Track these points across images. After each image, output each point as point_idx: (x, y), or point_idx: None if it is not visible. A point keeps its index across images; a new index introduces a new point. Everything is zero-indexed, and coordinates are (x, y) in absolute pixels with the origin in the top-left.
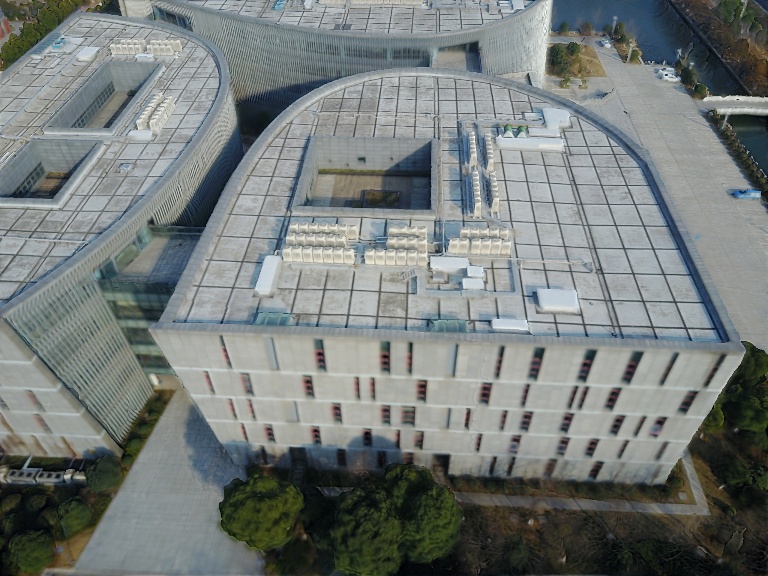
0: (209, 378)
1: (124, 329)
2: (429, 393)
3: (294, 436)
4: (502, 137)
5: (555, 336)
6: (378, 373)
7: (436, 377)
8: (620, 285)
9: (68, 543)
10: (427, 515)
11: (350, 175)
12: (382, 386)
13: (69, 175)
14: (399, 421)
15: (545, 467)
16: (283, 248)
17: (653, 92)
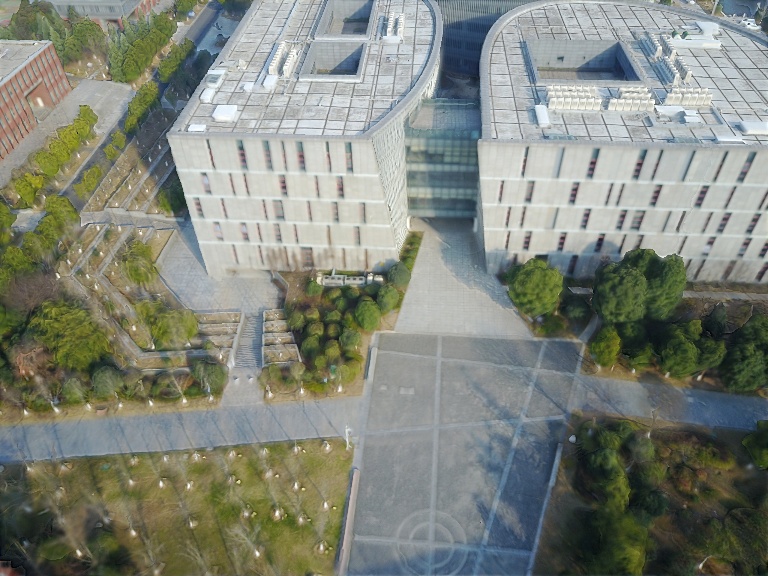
0: (502, 188)
1: (407, 172)
2: (660, 197)
3: (544, 243)
4: (673, 39)
5: None
6: (629, 179)
7: (671, 181)
8: None
9: (383, 318)
10: (671, 271)
11: (550, 71)
12: (628, 191)
13: (335, 71)
14: (628, 226)
15: (724, 270)
16: (551, 98)
17: None
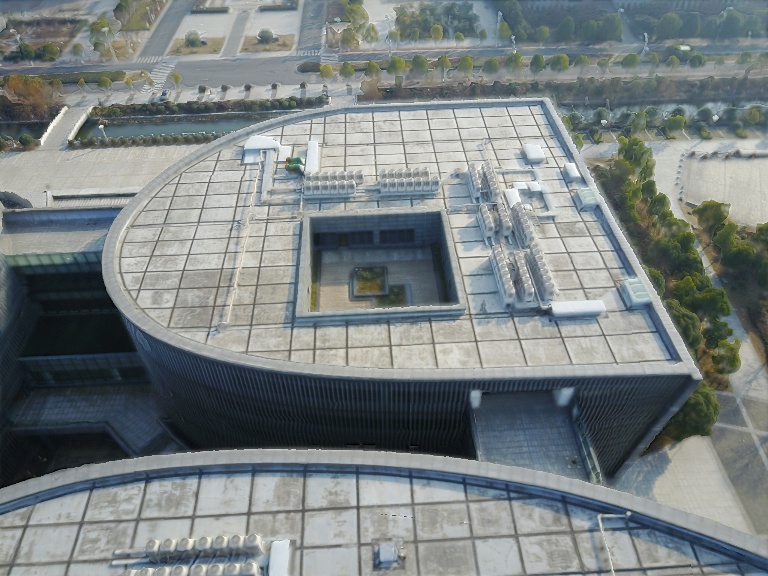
0: None
1: None
2: None
3: None
4: None
5: (567, 158)
6: None
7: None
8: (501, 133)
9: None
10: None
11: None
12: None
13: None
14: None
15: None
16: (553, 288)
17: (5, 171)
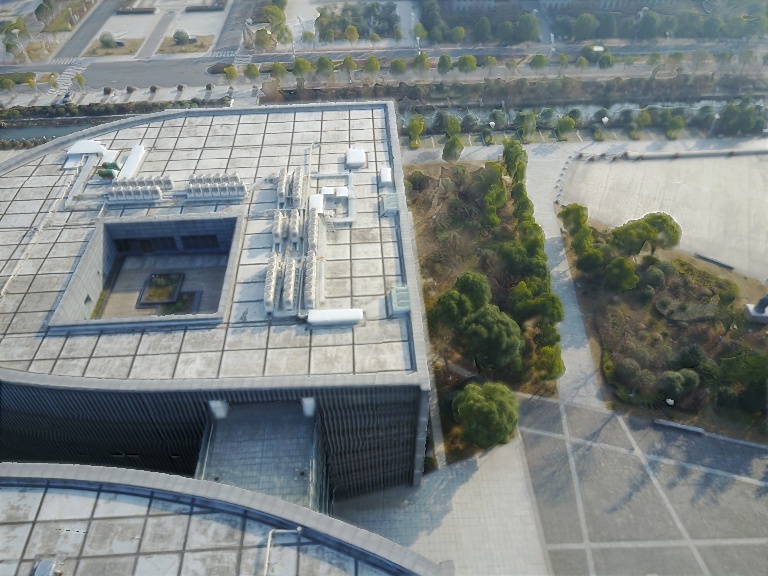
0: None
1: None
2: None
3: None
4: None
5: (389, 162)
6: None
7: None
8: (334, 137)
9: None
10: None
11: None
12: None
13: None
14: None
15: None
16: (310, 297)
17: None
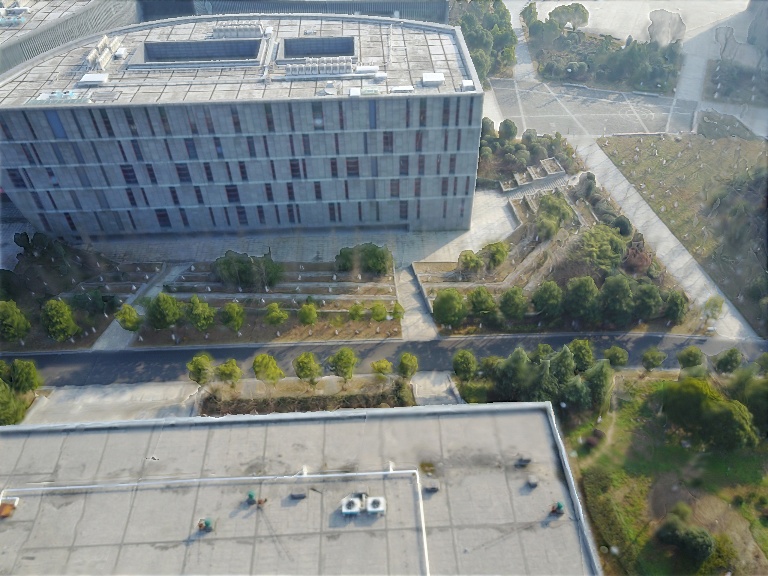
0: None
1: None
2: None
3: None
4: None
5: None
6: None
7: None
8: None
9: None
10: None
11: None
12: None
13: None
14: None
15: None
16: None
17: None
